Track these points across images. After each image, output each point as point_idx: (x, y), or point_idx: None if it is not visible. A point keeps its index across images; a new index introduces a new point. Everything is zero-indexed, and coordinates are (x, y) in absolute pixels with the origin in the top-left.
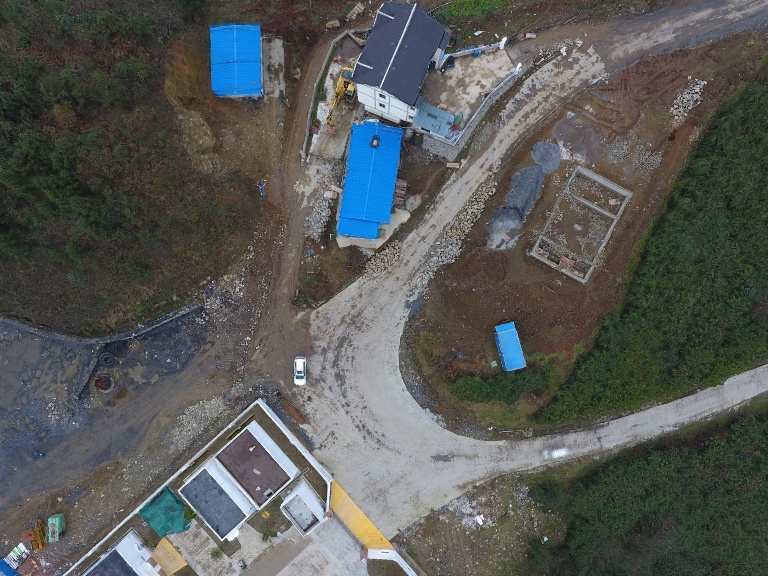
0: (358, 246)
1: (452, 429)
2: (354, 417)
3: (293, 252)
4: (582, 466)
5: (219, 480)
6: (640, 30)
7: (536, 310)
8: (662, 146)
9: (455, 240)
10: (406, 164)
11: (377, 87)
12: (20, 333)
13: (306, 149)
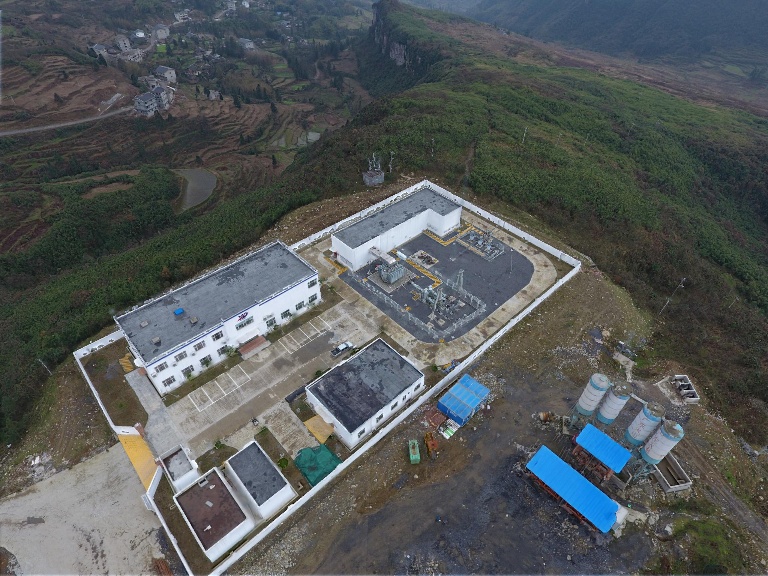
0: None
1: (6, 554)
2: (102, 568)
3: None
4: None
5: (248, 495)
6: None
7: None
8: None
9: None
10: None
11: None
12: None
13: None
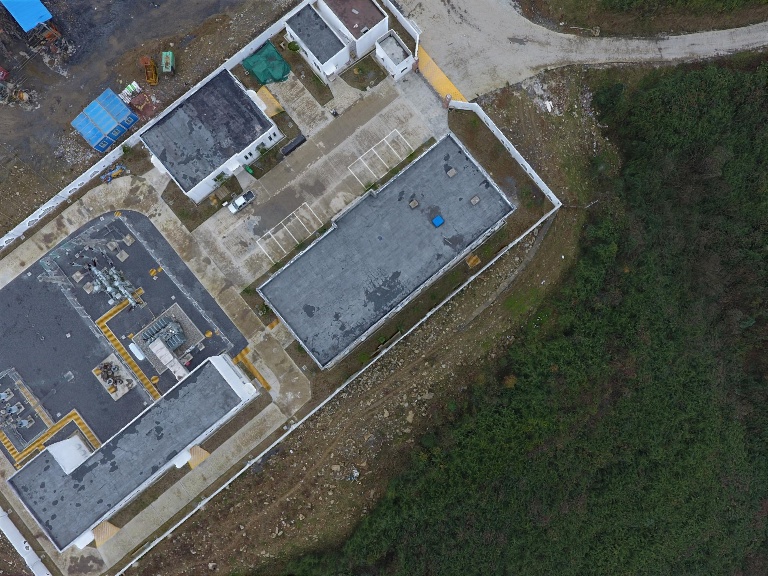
0: None
1: (527, 17)
2: None
3: None
4: (643, 74)
5: (321, 16)
6: None
7: None
8: None
9: None
10: None
11: None
12: None
13: None
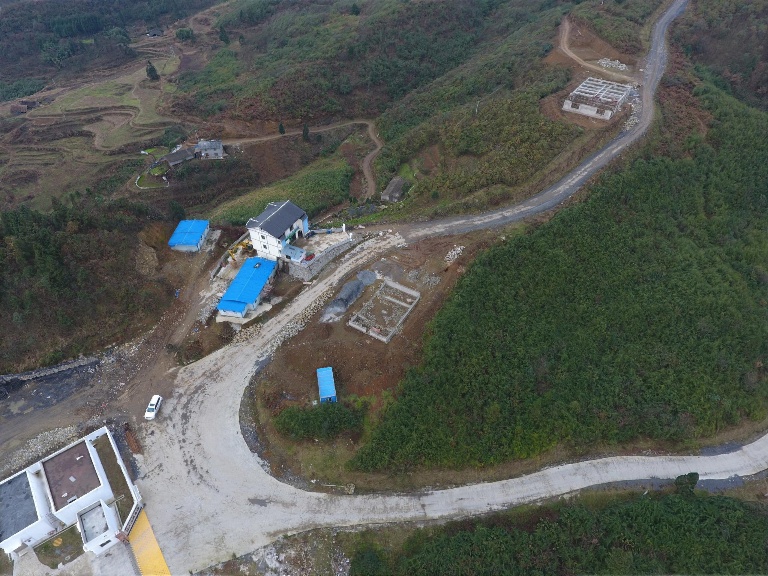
0: (230, 322)
1: (275, 476)
2: (186, 452)
3: (184, 329)
4: (406, 536)
5: (33, 484)
6: (425, 227)
7: (349, 358)
8: (441, 274)
9: (300, 321)
10: (277, 282)
11: (259, 230)
12: None
13: (215, 274)
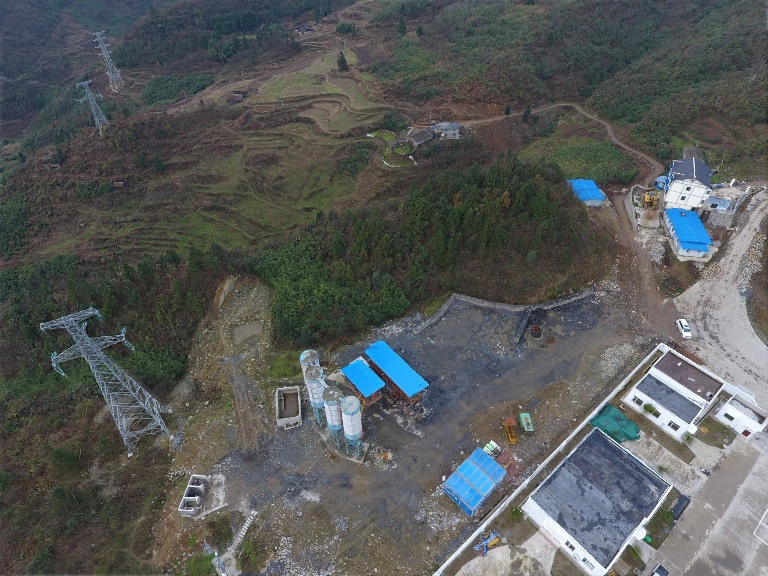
0: (693, 261)
1: None
2: (739, 364)
3: (646, 269)
4: None
5: None
6: None
7: None
8: None
9: (755, 260)
10: None
11: (689, 181)
12: (467, 306)
13: None
